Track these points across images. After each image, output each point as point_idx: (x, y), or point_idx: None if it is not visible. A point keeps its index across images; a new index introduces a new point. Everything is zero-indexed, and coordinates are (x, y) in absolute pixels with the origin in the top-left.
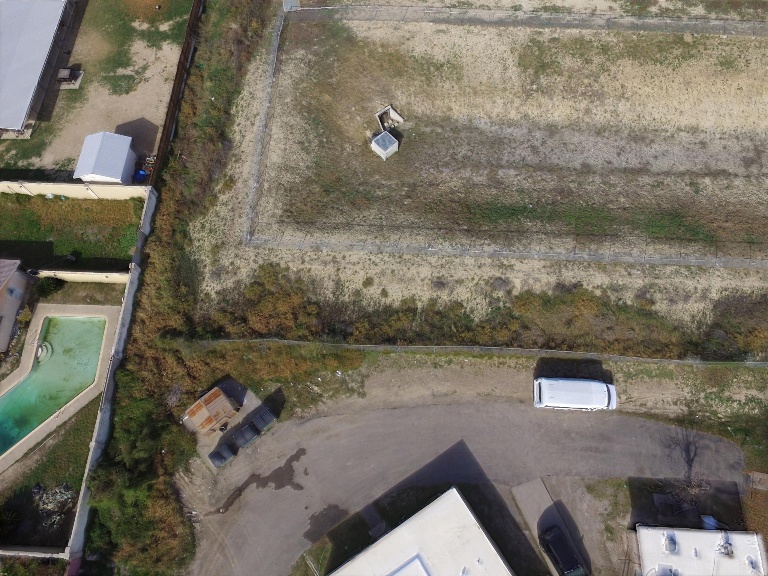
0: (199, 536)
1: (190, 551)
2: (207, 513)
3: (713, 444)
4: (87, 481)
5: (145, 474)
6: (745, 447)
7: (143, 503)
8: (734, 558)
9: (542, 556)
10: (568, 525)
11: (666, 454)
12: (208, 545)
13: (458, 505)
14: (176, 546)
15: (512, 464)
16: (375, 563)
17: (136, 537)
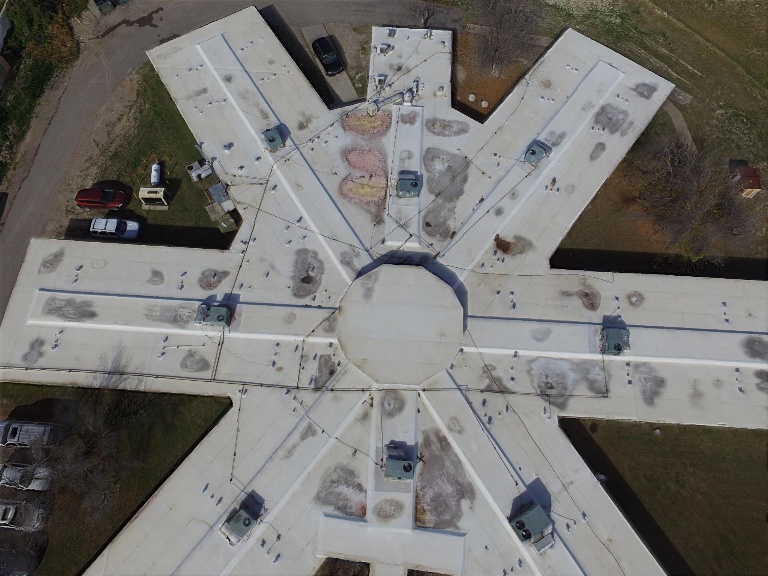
0: (83, 49)
1: (76, 55)
2: (90, 38)
3: (446, 10)
4: (7, 3)
5: (48, 7)
6: (468, 12)
7: (46, 28)
8: (433, 41)
9: (315, 60)
10: (336, 47)
11: (412, 14)
12: (89, 53)
13: (254, 13)
14: (66, 51)
15: (305, 17)
16: (193, 38)
17: (39, 42)
